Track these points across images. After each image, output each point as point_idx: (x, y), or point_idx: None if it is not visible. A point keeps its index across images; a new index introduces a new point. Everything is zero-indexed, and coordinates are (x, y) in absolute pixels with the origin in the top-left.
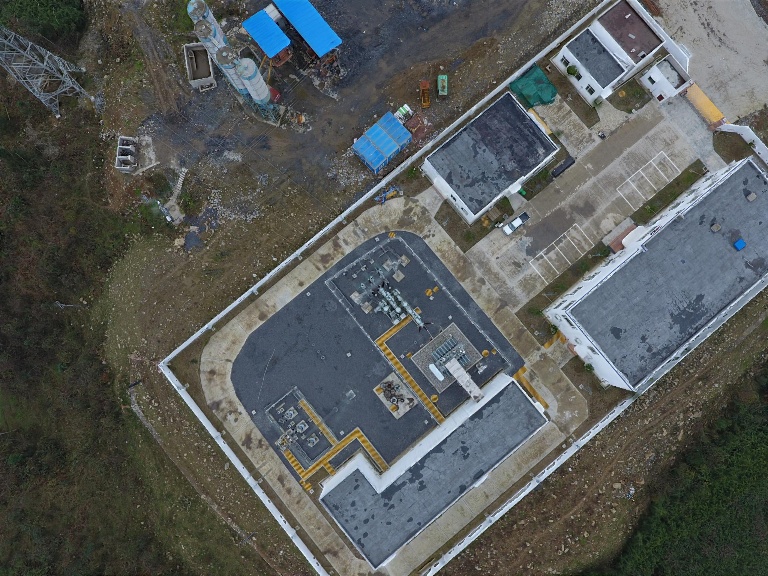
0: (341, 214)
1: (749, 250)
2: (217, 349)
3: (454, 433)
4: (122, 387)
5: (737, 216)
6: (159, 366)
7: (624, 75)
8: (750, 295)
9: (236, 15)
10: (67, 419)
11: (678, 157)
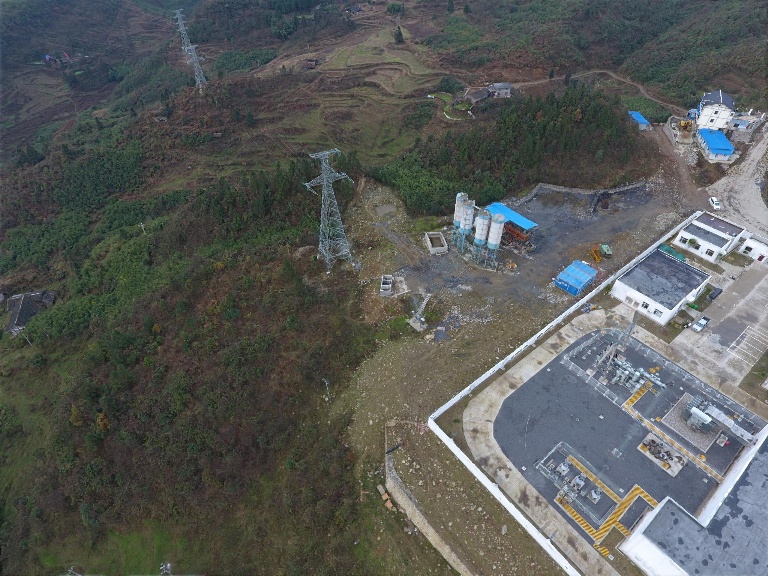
0: (562, 314)
1: None
2: (476, 411)
3: (751, 466)
4: (364, 469)
5: None
6: (430, 418)
7: (727, 247)
8: None
9: (453, 225)
10: (268, 538)
11: None
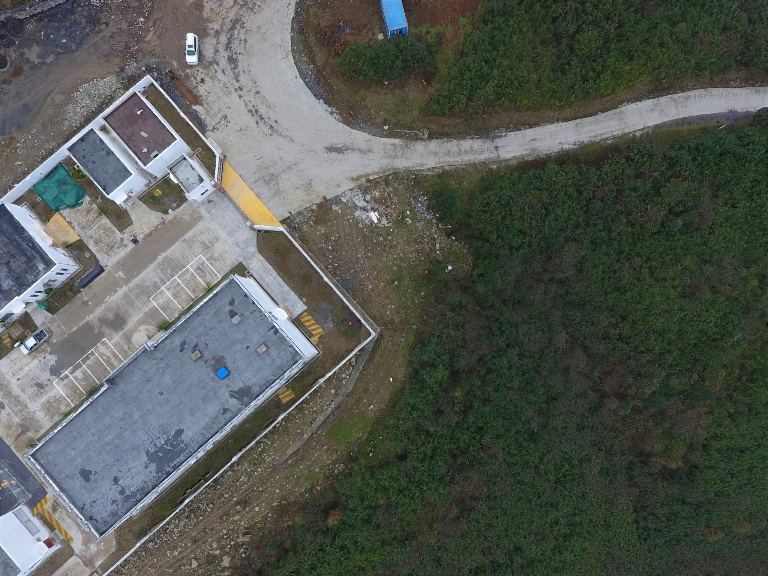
0: None
1: (234, 378)
2: None
3: None
4: None
5: (222, 341)
6: None
7: None
8: (285, 412)
9: None
10: None
11: (218, 261)
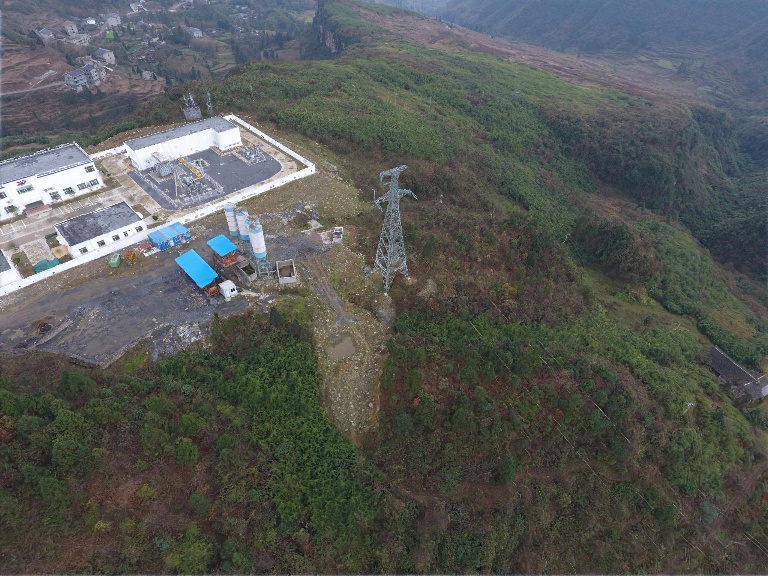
0: (206, 208)
1: None
2: None
3: None
4: None
5: None
6: None
7: None
8: None
9: None
10: None
11: None
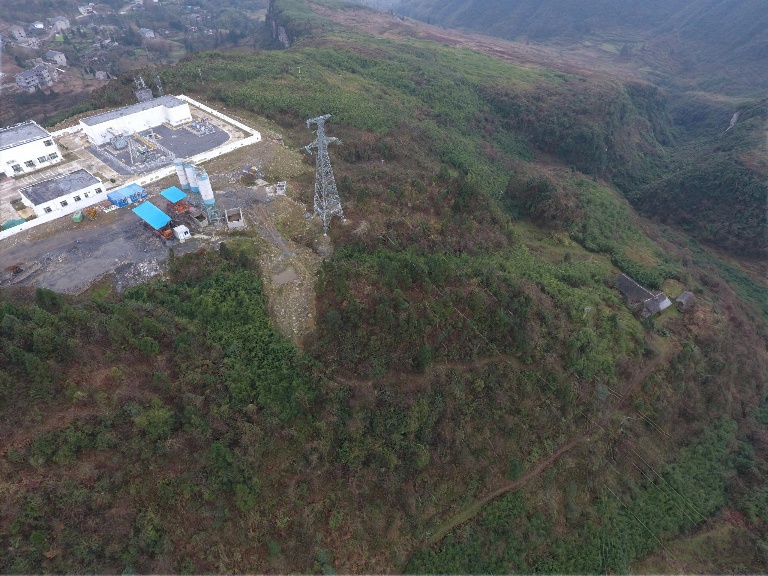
0: None
1: None
2: None
3: None
4: None
5: None
6: None
7: None
8: None
9: None
10: None
11: None
